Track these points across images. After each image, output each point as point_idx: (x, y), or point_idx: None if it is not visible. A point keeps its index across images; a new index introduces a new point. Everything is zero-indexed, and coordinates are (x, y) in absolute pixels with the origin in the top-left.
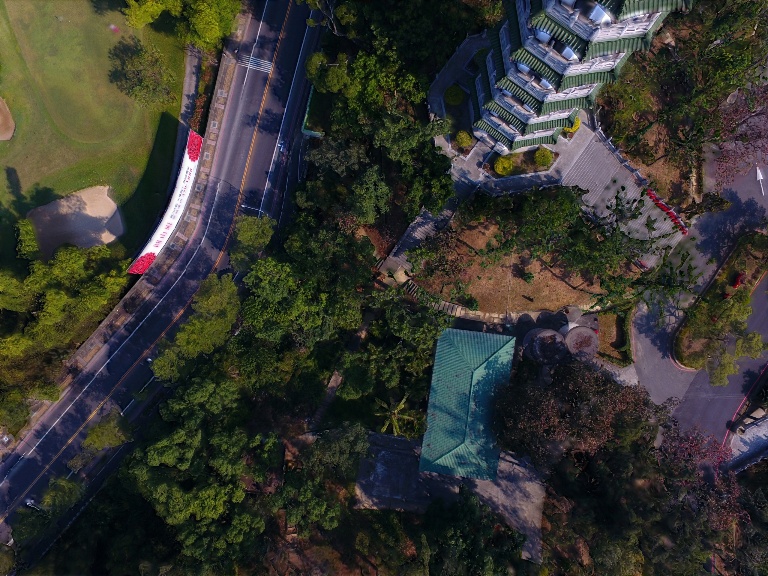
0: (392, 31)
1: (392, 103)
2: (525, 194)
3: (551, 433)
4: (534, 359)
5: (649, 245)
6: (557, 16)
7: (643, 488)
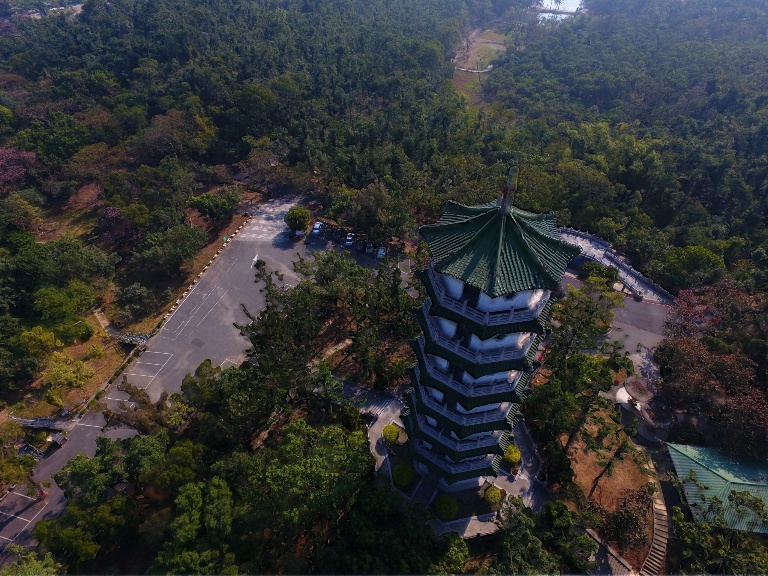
0: (419, 570)
1: (494, 574)
2: (543, 429)
3: (761, 401)
4: (676, 427)
5: (555, 336)
6: (528, 347)
7: (757, 336)
